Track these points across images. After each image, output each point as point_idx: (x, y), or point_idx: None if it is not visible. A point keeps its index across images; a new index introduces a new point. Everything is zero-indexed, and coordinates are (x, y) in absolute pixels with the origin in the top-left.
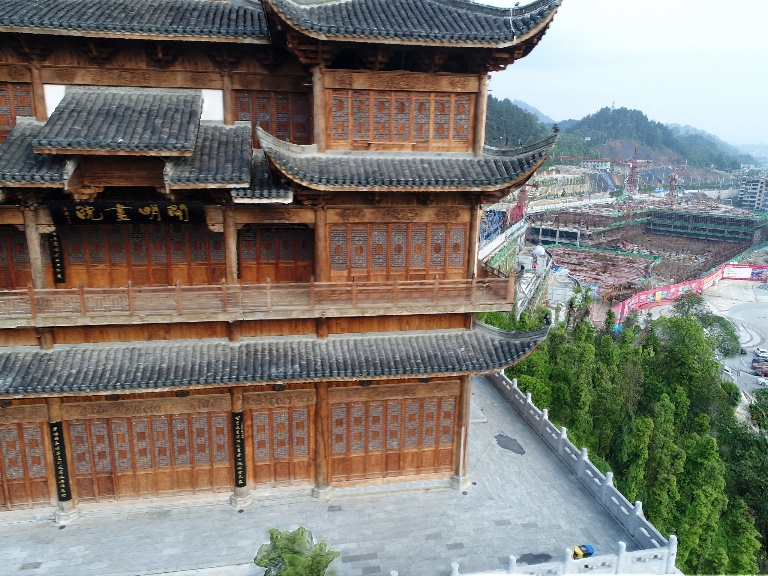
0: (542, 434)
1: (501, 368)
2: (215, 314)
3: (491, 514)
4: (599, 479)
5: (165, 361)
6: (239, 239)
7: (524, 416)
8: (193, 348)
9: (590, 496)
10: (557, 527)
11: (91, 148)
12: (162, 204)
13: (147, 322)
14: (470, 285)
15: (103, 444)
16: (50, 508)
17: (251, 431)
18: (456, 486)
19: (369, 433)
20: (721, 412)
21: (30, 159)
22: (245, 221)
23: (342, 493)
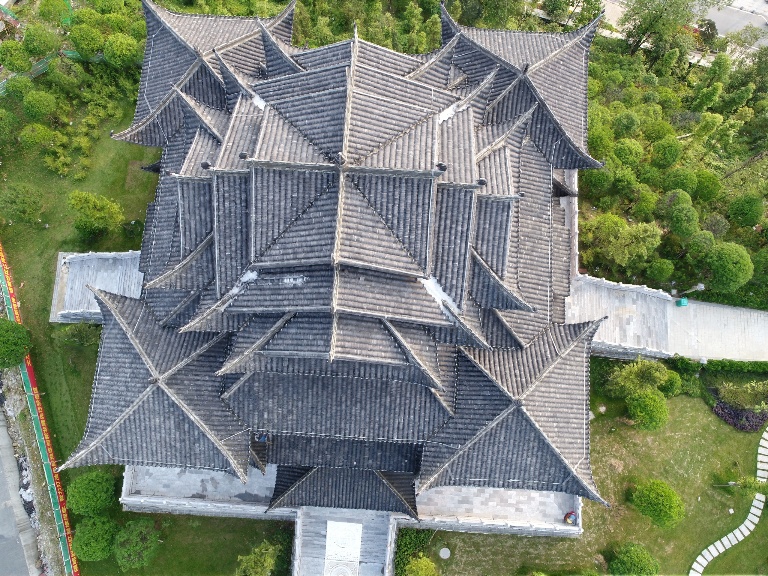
0: None
1: None
2: None
3: None
4: None
5: None
6: None
7: None
8: None
9: None
10: None
11: None
12: None
13: None
14: None
15: None
16: None
17: None
18: None
19: None
20: None
21: None
22: None
23: None
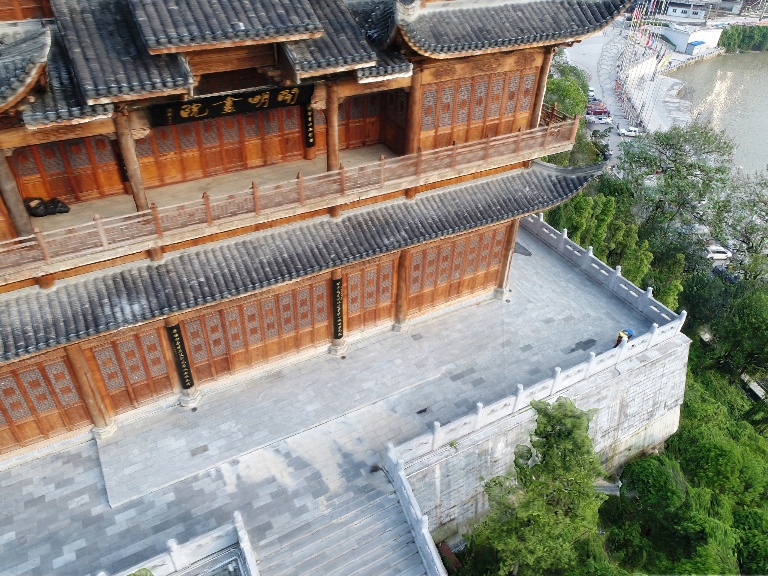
0: (537, 234)
1: None
2: (334, 199)
3: (537, 315)
4: (607, 271)
5: (283, 250)
6: None
7: None
8: (301, 231)
9: (597, 284)
10: (588, 316)
11: (216, 41)
12: (275, 90)
13: (272, 219)
14: (545, 132)
15: (217, 332)
16: (174, 396)
17: (346, 291)
18: (500, 297)
19: (439, 270)
20: (587, 162)
21: (123, 55)
22: (347, 94)
23: (415, 322)
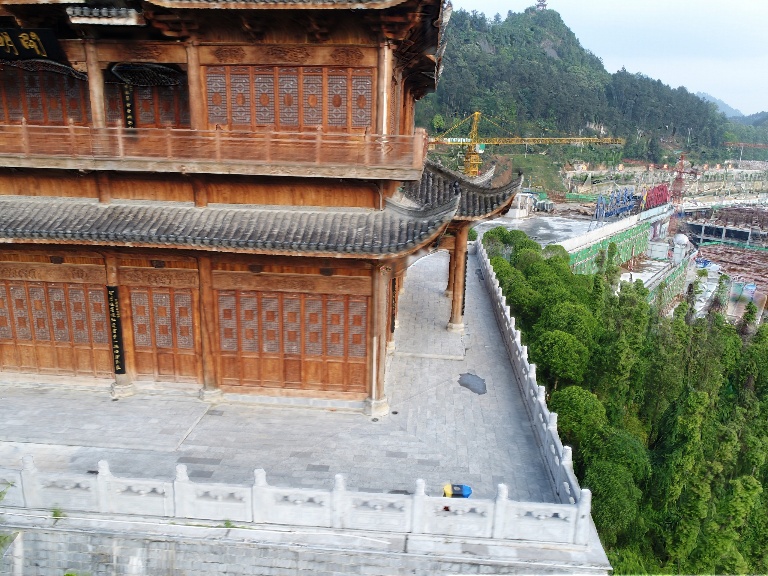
0: (519, 377)
1: (399, 252)
2: (64, 160)
3: (389, 444)
4: None
5: (23, 215)
6: (134, 97)
7: (512, 359)
8: (59, 206)
9: (535, 445)
10: (463, 469)
11: None
12: (12, 32)
13: None
14: (363, 142)
15: None
16: None
17: (130, 311)
18: (368, 411)
19: (263, 331)
20: None
21: None
22: (109, 59)
23: (234, 400)
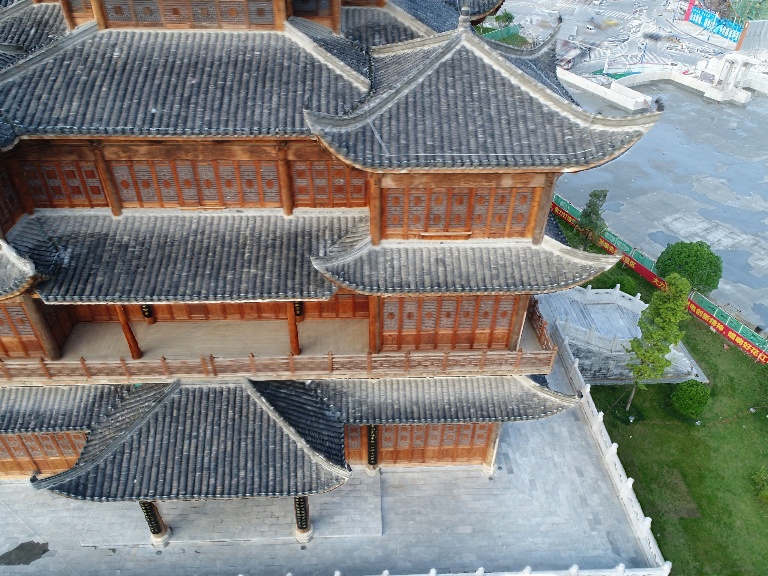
0: None
1: None
2: None
3: None
4: None
5: None
6: None
7: None
8: None
9: None
10: None
11: None
12: None
13: None
14: None
15: None
16: None
17: None
18: None
19: None
20: None
21: None
22: None
23: None
